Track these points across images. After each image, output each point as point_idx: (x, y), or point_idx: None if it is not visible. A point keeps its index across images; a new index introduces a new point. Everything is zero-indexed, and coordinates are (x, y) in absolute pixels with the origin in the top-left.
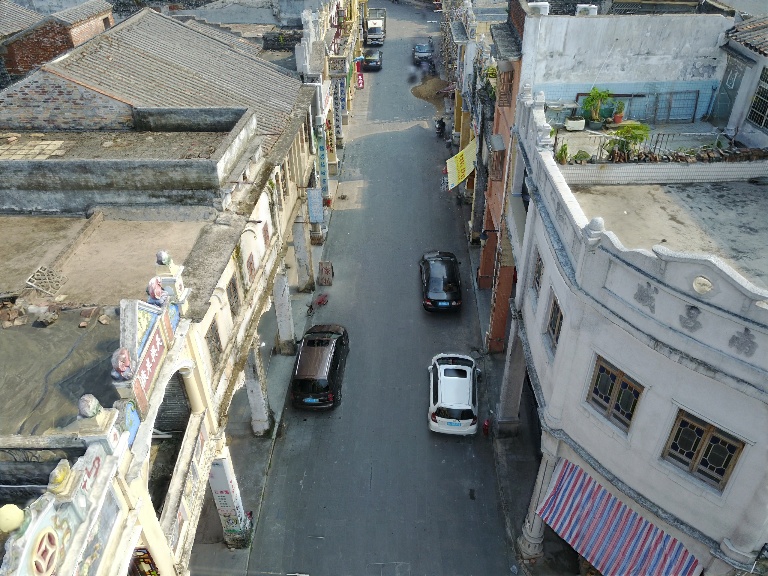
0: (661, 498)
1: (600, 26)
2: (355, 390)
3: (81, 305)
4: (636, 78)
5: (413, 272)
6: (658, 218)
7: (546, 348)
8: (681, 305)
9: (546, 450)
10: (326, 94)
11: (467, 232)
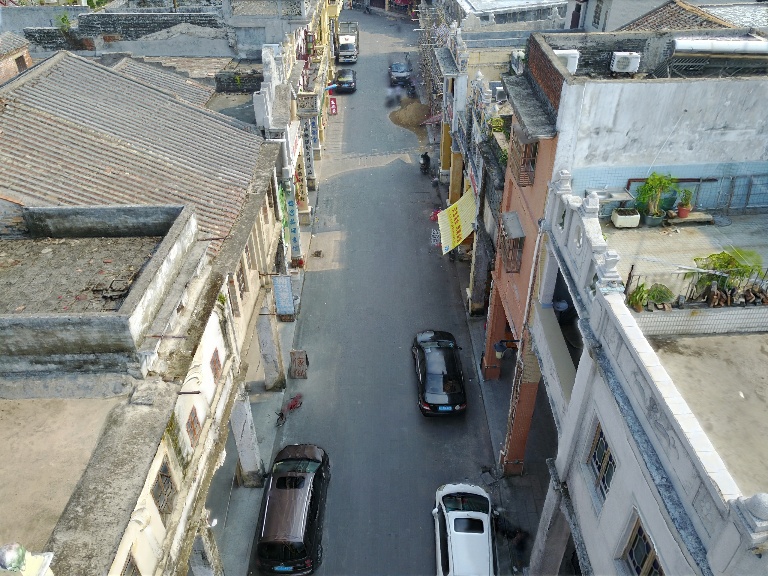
0: None
1: (664, 94)
2: (339, 539)
3: None
4: (707, 158)
5: (404, 357)
6: None
7: None
8: None
9: None
10: (294, 140)
11: (464, 299)
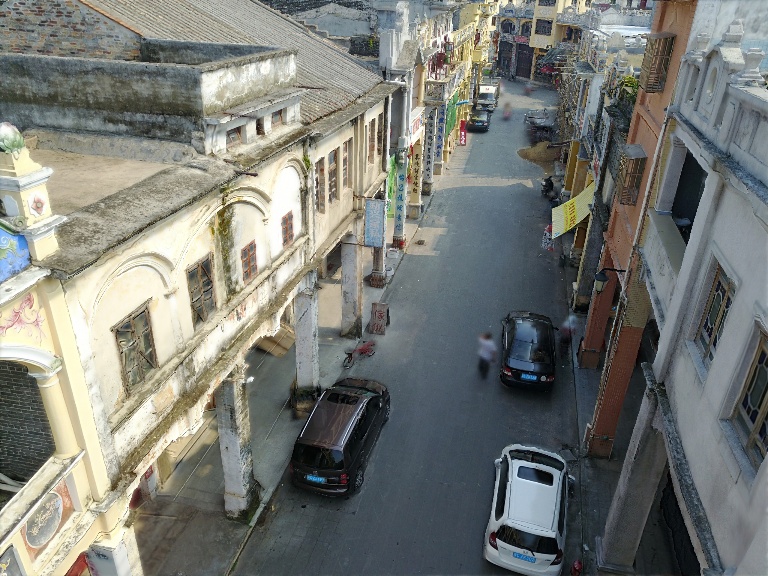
0: None
1: None
2: (384, 476)
3: None
4: None
5: (492, 334)
6: None
7: (732, 447)
8: None
9: None
10: (416, 116)
11: (569, 297)
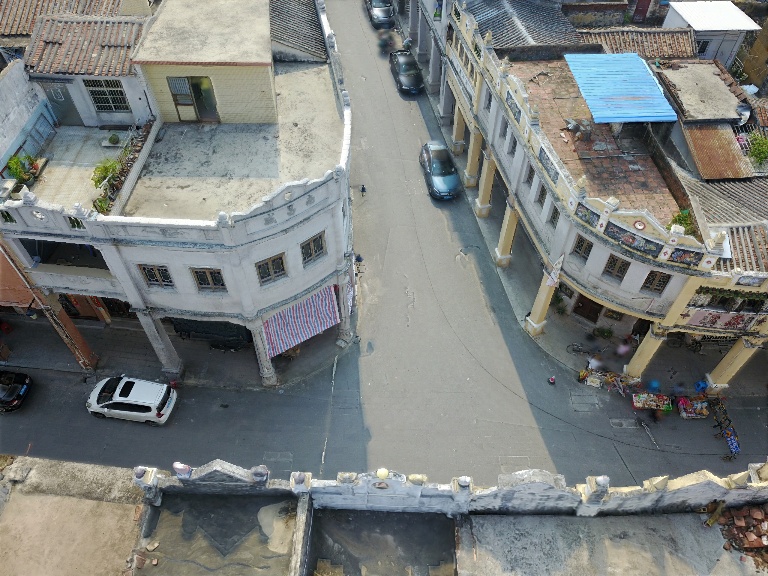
0: (313, 281)
1: None
2: None
3: (129, 569)
4: (13, 135)
5: None
6: (179, 193)
7: (212, 294)
8: (285, 210)
9: (257, 328)
10: None
11: None
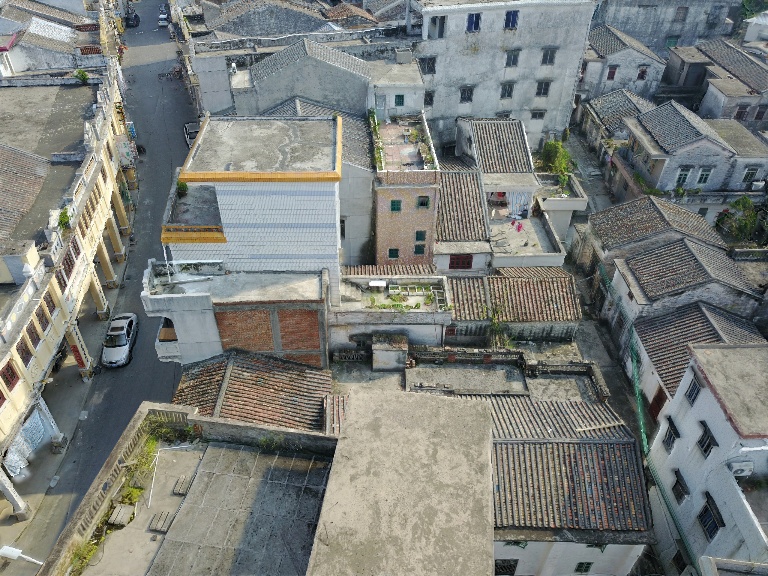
0: None
1: None
2: None
3: None
4: None
5: None
6: None
7: None
8: None
9: None
10: None
11: None
